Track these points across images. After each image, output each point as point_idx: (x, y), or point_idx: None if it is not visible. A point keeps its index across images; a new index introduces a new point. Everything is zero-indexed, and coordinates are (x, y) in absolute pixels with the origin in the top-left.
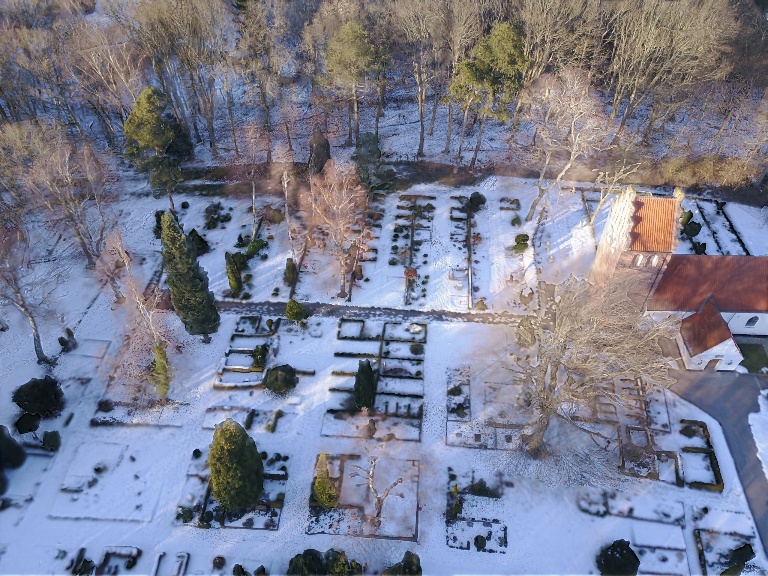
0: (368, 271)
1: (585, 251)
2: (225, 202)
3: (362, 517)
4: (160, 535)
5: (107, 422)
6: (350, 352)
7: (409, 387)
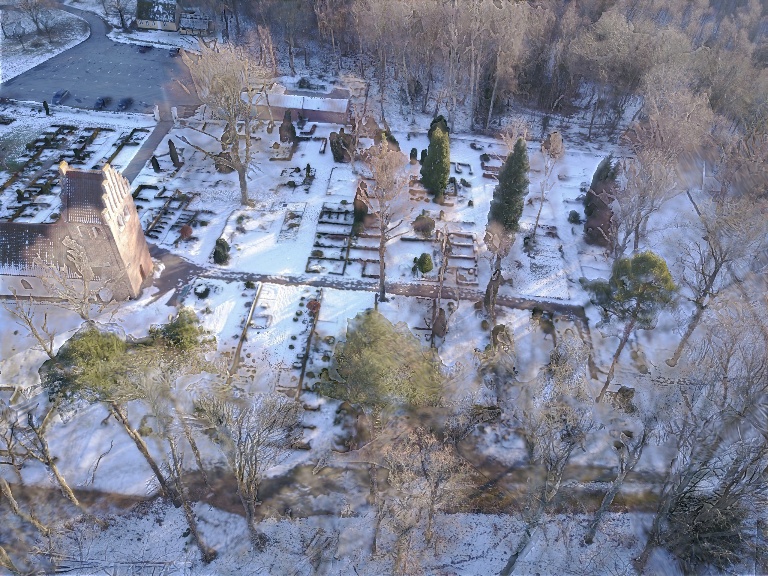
0: None
1: None
2: None
3: None
4: (476, 180)
5: (544, 225)
6: (373, 247)
7: (328, 229)
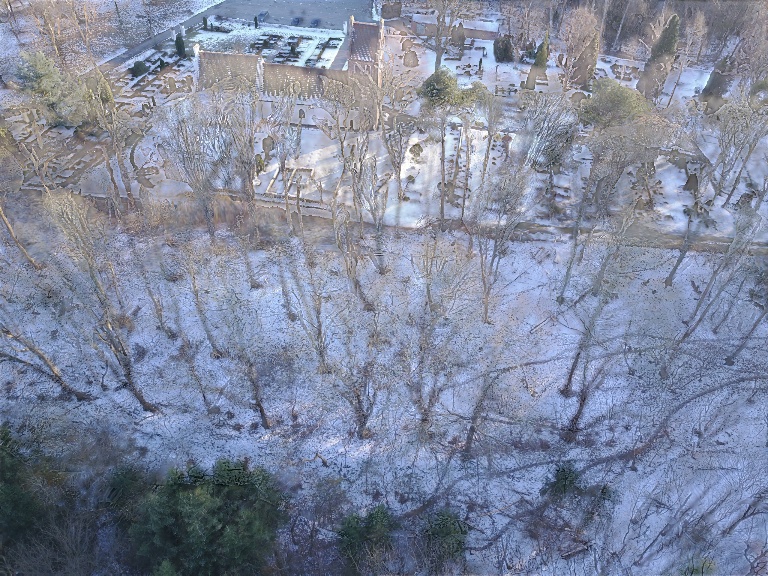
0: None
1: None
2: (703, 229)
3: (522, 70)
4: None
5: None
6: None
7: None
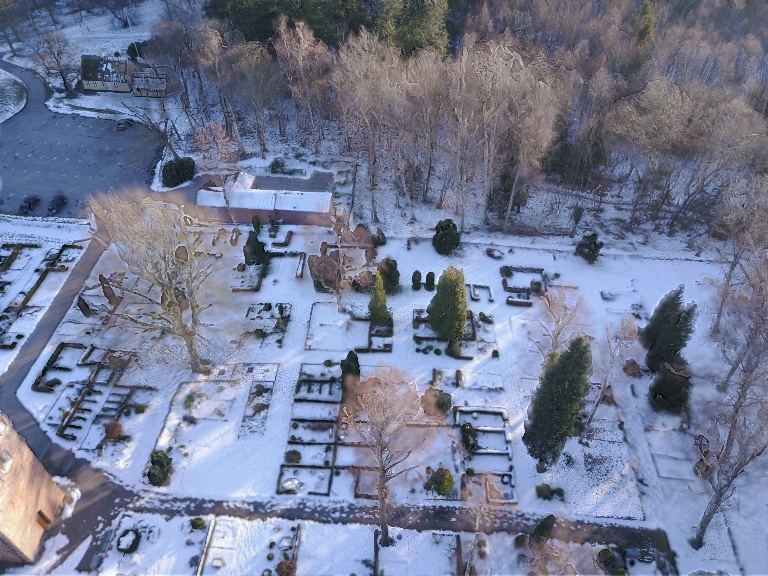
0: None
1: None
2: None
3: (352, 313)
4: (499, 311)
5: (594, 384)
6: None
7: (307, 411)
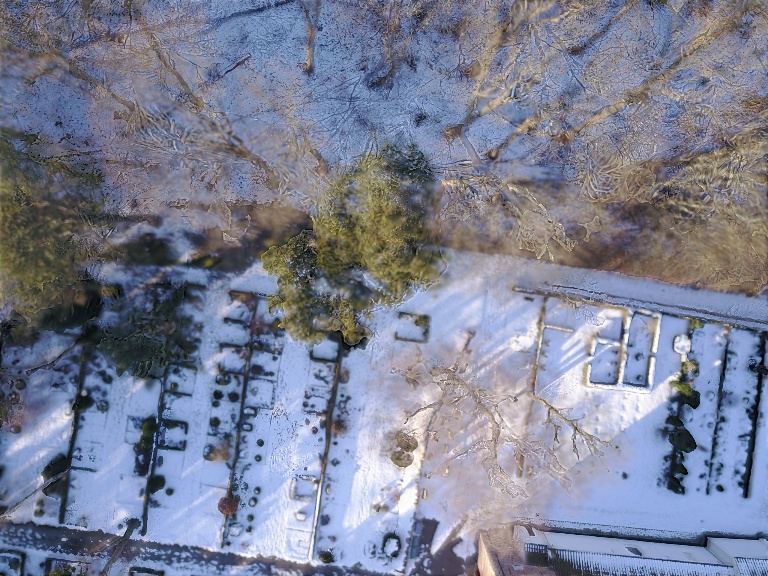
0: (172, 470)
1: (503, 455)
2: None
3: None
4: None
5: None
6: None
7: None
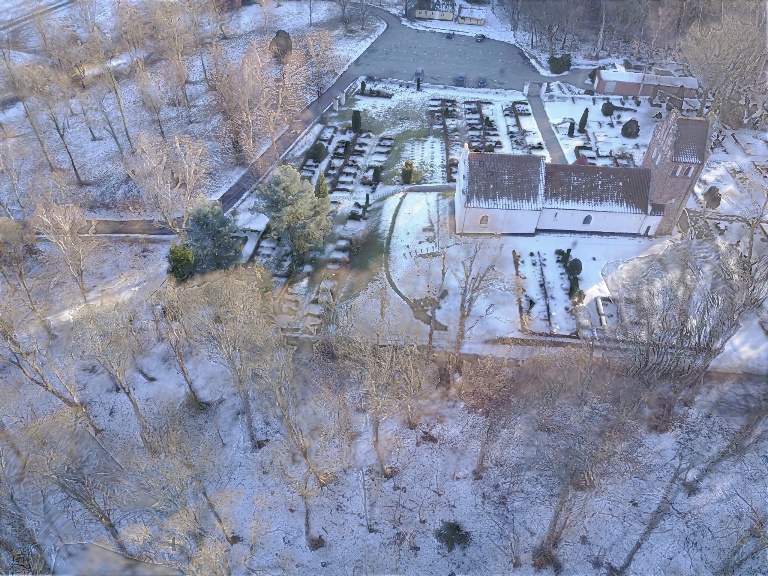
0: None
1: None
2: None
3: None
4: None
5: None
6: None
7: None
